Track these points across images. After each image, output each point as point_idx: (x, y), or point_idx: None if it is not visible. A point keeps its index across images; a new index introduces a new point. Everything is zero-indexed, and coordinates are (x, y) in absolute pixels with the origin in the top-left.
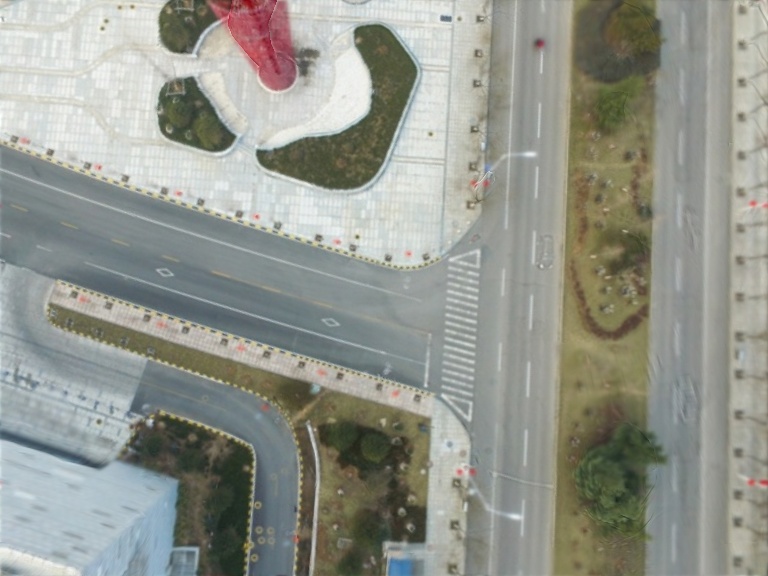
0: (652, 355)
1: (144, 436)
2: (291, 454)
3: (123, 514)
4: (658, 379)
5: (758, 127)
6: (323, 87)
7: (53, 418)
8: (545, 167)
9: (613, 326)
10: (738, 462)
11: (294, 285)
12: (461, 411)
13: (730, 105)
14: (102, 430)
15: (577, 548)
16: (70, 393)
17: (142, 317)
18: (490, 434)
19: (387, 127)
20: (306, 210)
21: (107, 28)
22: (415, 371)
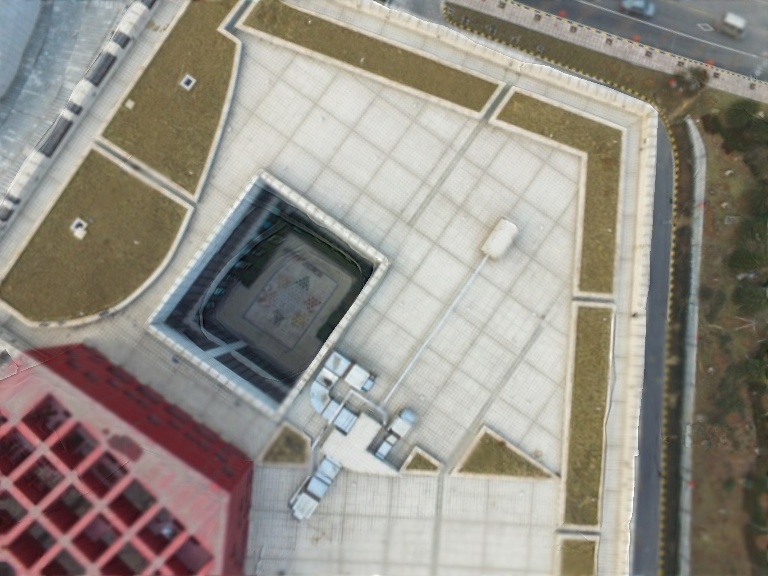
0: None
1: None
2: (667, 150)
3: None
4: None
5: None
6: None
7: None
8: None
9: None
10: None
11: None
12: None
13: None
14: None
15: None
16: None
17: (533, 16)
18: None
19: None
20: None
21: None
22: None
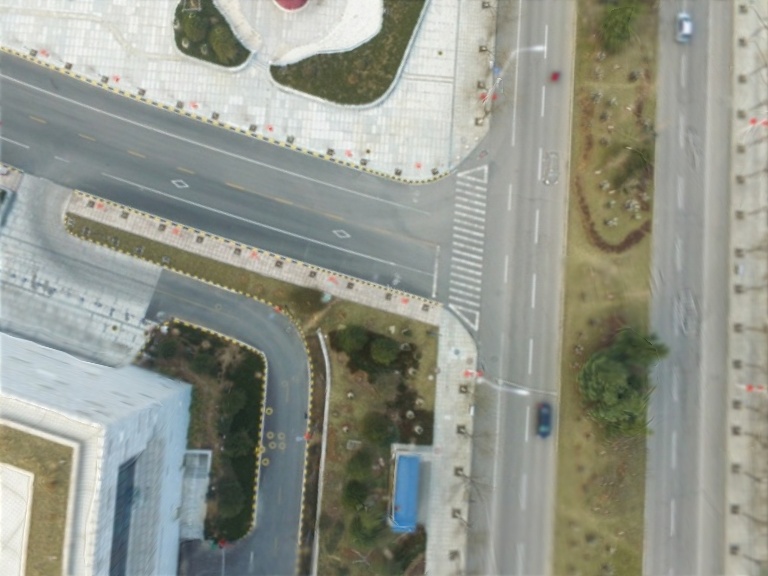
0: (654, 269)
1: (159, 341)
2: (302, 362)
3: (141, 399)
4: (660, 292)
5: (759, 50)
6: (335, 7)
7: (70, 324)
8: (551, 87)
9: (616, 240)
10: (737, 373)
11: (306, 197)
12: (468, 320)
13: (732, 30)
14: (118, 336)
15: (580, 452)
16: (86, 300)
17: (157, 226)
18: (496, 343)
19: (398, 45)
20: (318, 125)
21: None
22: (423, 282)
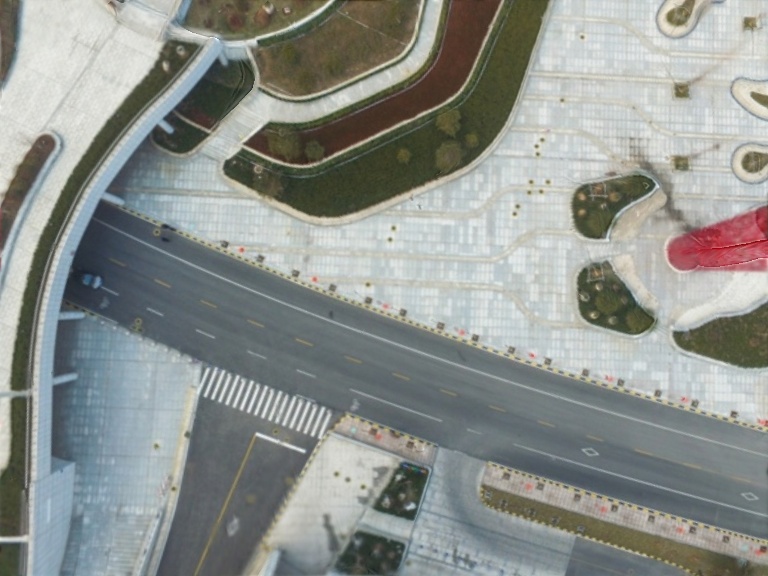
0: None
1: None
2: None
3: None
4: None
5: None
6: None
7: None
8: None
9: None
10: None
11: (713, 461)
12: None
13: None
14: None
15: None
16: (506, 572)
17: (573, 497)
18: None
19: None
20: (721, 388)
21: (519, 213)
22: None
